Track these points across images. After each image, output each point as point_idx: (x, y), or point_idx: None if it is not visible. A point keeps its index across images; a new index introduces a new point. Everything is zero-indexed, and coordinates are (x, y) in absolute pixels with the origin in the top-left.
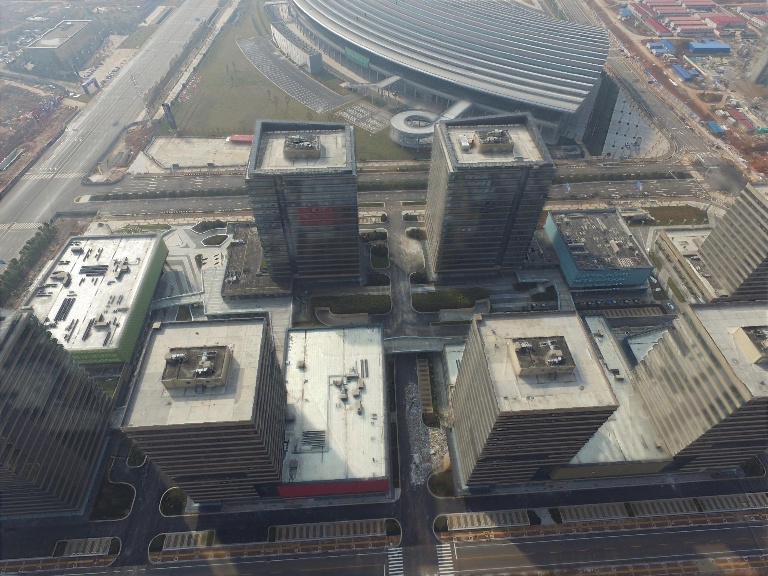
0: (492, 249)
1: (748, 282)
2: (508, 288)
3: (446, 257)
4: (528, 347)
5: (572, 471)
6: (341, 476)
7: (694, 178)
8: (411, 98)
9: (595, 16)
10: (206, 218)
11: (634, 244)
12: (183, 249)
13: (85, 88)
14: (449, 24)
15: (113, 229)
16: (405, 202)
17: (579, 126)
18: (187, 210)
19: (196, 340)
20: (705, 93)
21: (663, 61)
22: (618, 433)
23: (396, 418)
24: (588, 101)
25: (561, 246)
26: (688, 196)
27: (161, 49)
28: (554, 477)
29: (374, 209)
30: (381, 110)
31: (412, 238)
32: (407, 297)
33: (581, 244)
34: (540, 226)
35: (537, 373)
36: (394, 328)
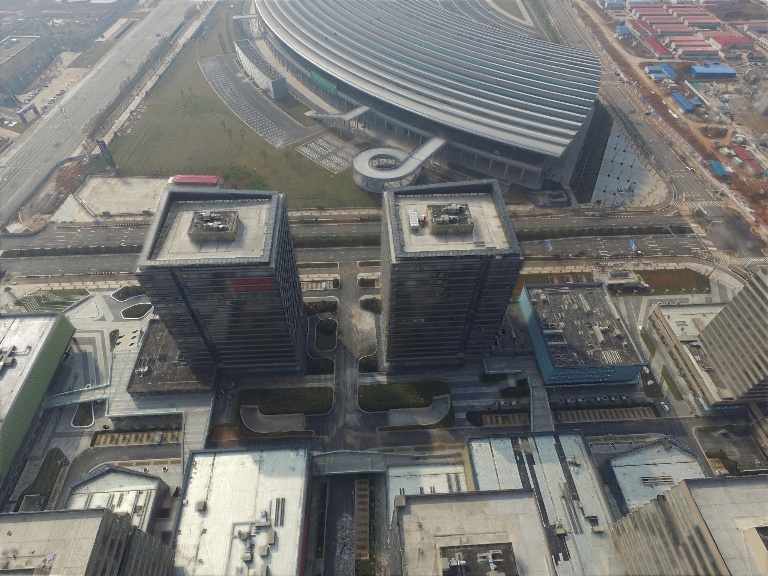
0: (452, 338)
1: (758, 387)
2: (473, 379)
3: (398, 346)
4: (460, 565)
5: None
6: None
7: (695, 233)
8: (382, 130)
9: (590, 34)
10: (131, 281)
11: (622, 331)
12: (98, 322)
13: (21, 116)
14: (425, 48)
15: (21, 295)
16: (362, 262)
17: (567, 166)
18: (110, 271)
19: (5, 546)
20: (708, 127)
21: (662, 88)
22: None
23: (322, 567)
24: (578, 135)
25: (536, 331)
26: (688, 256)
27: (114, 69)
28: None
29: (326, 271)
30: (347, 145)
31: (366, 310)
32: (353, 390)
33: (559, 331)
34: (516, 295)
35: None
36: (333, 434)
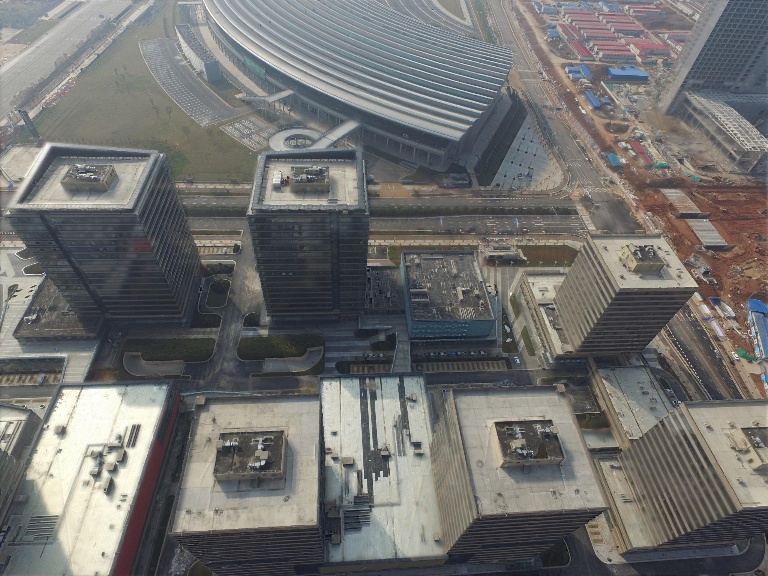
0: (324, 293)
1: (589, 340)
2: (348, 334)
3: (275, 300)
4: (233, 446)
5: (337, 568)
6: (57, 575)
7: (579, 215)
8: (306, 114)
9: (523, 35)
10: None
11: (482, 291)
12: None
13: None
14: (351, 38)
15: None
16: None
17: (475, 153)
18: None
19: None
20: (611, 123)
21: (578, 87)
22: (397, 522)
23: None
24: (491, 126)
25: (406, 291)
26: (568, 234)
27: (54, 46)
28: (322, 572)
29: (229, 237)
30: (270, 126)
31: None
32: (234, 342)
33: (424, 290)
34: None
35: (239, 478)
36: (208, 379)
